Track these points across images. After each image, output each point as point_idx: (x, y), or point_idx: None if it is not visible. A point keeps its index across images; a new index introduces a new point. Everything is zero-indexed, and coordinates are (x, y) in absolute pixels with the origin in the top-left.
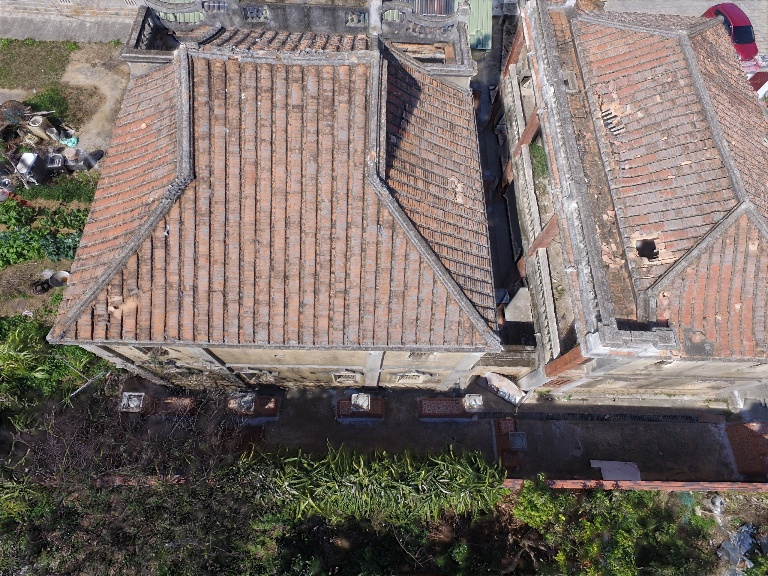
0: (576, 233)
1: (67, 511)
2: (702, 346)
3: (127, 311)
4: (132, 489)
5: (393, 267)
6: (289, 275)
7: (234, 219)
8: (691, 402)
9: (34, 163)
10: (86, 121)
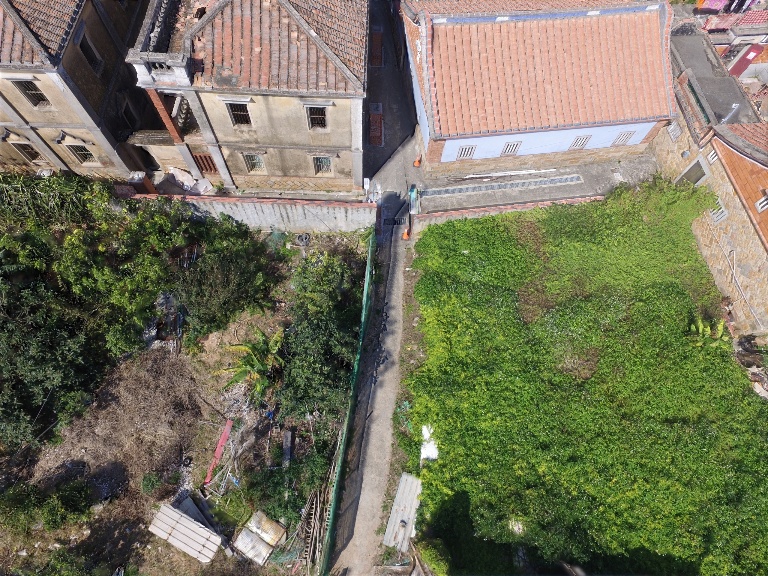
0: None
1: None
2: (229, 79)
3: None
4: None
5: None
6: None
7: None
8: (345, 197)
9: None
10: None
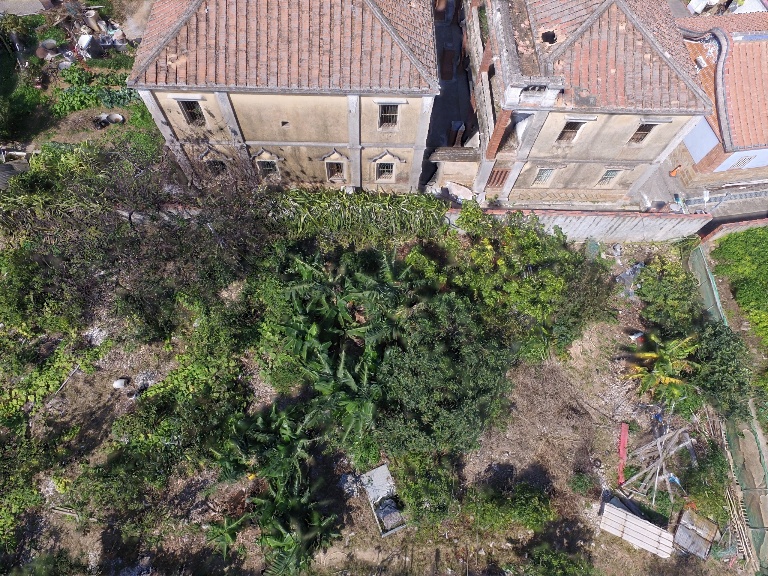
0: (500, 33)
1: (132, 240)
2: (588, 100)
3: (180, 64)
4: (179, 219)
5: (363, 35)
6: (291, 40)
7: (253, 1)
8: (611, 207)
9: (90, 42)
10: (128, 18)
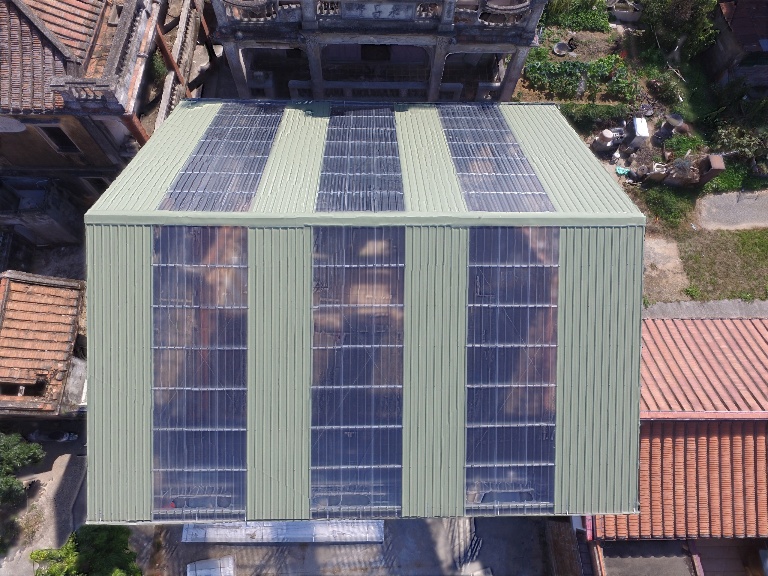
0: None
1: None
2: None
3: None
4: None
5: None
6: None
7: None
8: None
9: None
10: None
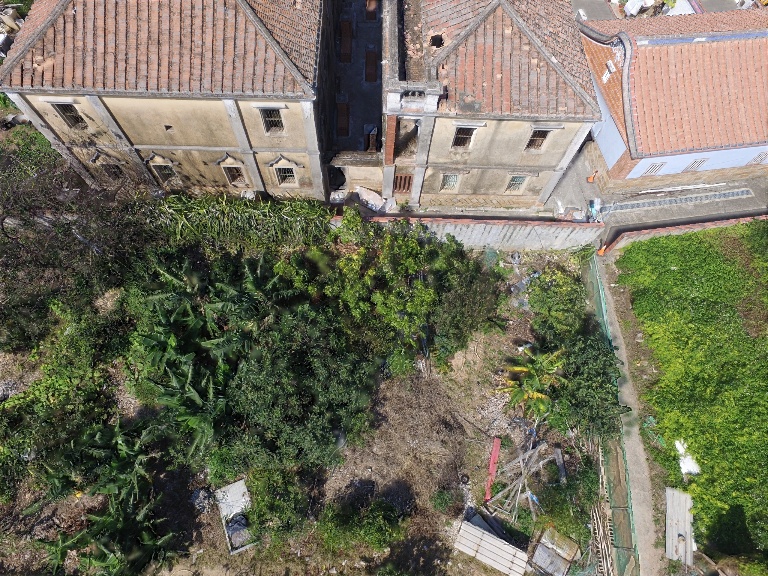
0: None
1: (12, 245)
2: (472, 105)
3: (46, 67)
4: None
5: (237, 38)
6: (162, 43)
7: (122, 2)
8: (525, 213)
9: (4, 41)
10: None
